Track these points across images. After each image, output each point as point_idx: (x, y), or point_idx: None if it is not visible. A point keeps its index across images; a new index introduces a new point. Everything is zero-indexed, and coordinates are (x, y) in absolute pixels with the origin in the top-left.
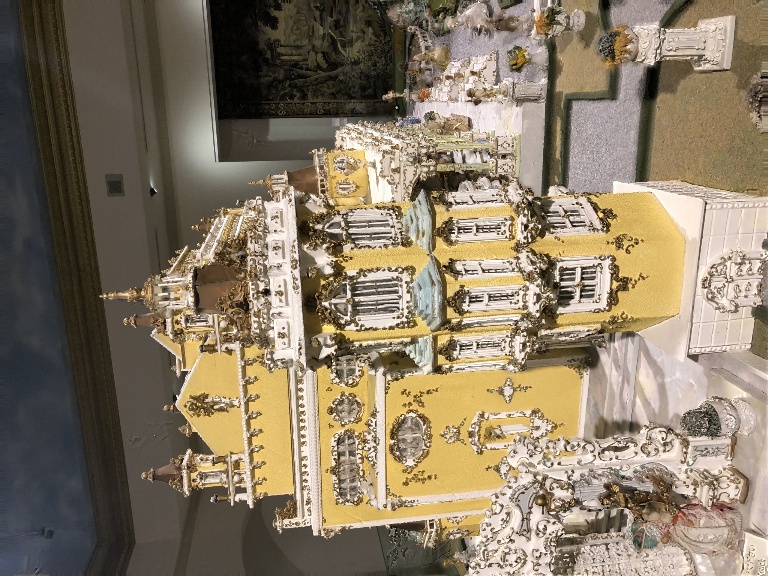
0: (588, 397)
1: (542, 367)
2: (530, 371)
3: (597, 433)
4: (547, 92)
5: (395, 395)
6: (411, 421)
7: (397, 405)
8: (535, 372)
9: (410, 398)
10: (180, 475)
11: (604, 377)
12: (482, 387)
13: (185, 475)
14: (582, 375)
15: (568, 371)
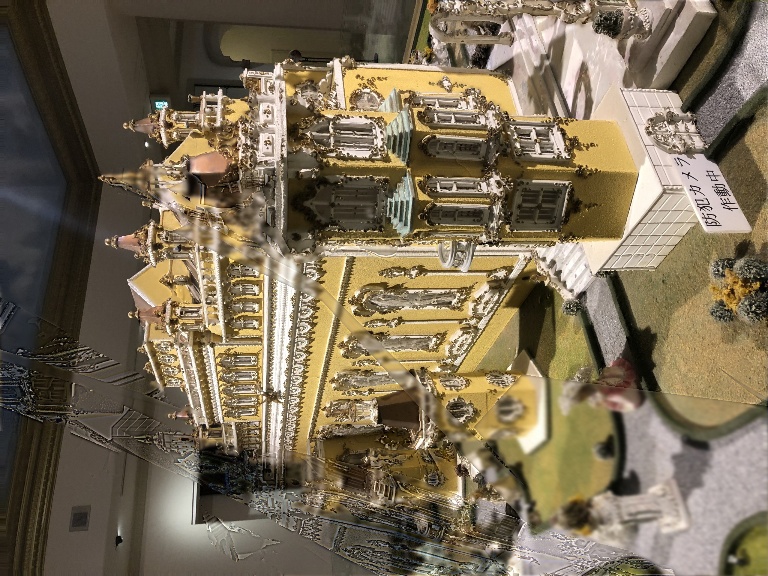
0: (518, 96)
1: (471, 74)
2: (462, 75)
3: (530, 95)
4: (451, 64)
5: (351, 79)
6: (367, 97)
7: (353, 85)
8: (466, 77)
9: (364, 82)
10: (146, 230)
11: (519, 56)
12: (424, 81)
13: (151, 228)
14: (507, 83)
15: (494, 80)
